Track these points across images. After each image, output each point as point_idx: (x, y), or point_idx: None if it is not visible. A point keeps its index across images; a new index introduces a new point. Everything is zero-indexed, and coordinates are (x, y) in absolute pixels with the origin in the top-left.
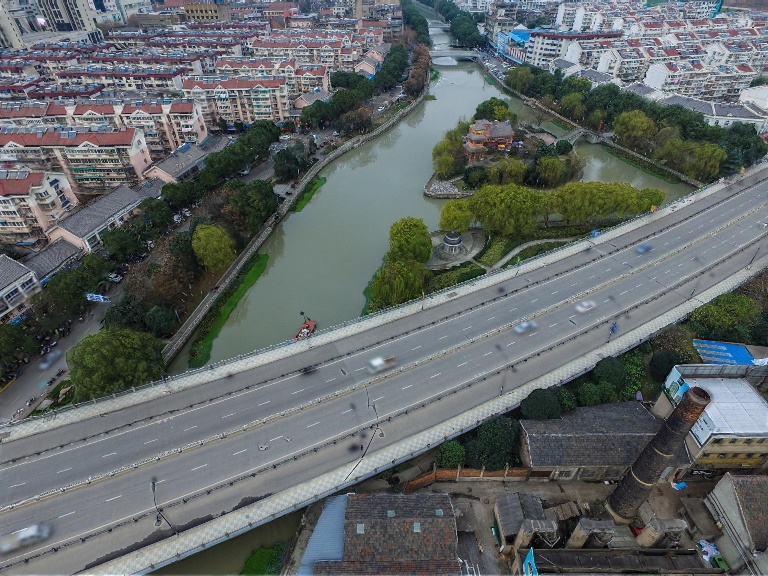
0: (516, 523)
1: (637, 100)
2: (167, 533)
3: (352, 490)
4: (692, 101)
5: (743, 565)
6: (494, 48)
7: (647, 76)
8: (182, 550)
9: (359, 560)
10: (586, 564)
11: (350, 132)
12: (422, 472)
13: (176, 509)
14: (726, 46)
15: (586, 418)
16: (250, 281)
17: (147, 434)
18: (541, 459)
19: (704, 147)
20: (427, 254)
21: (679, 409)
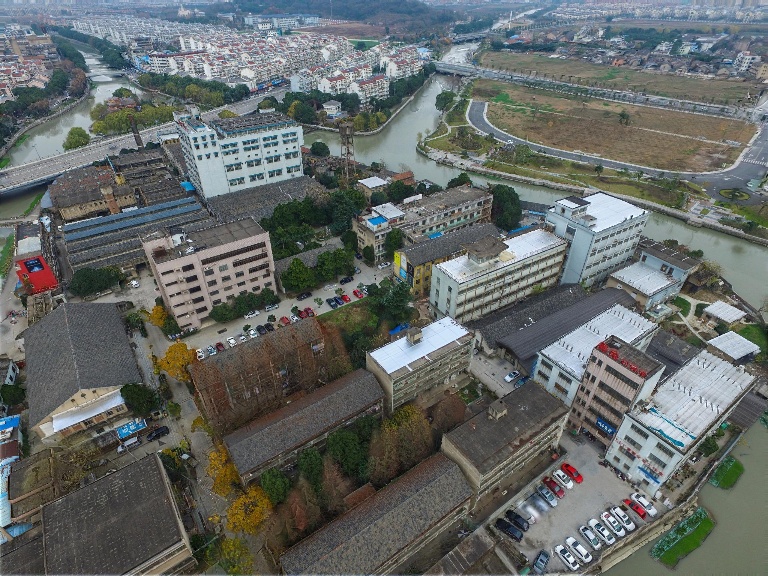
0: None
1: (199, 81)
2: None
3: None
4: (221, 78)
5: None
6: (135, 67)
7: (205, 70)
8: None
9: None
10: None
11: (37, 116)
12: None
13: (8, 184)
14: (248, 54)
15: None
16: (4, 164)
17: None
18: None
19: (215, 93)
20: (85, 136)
21: None
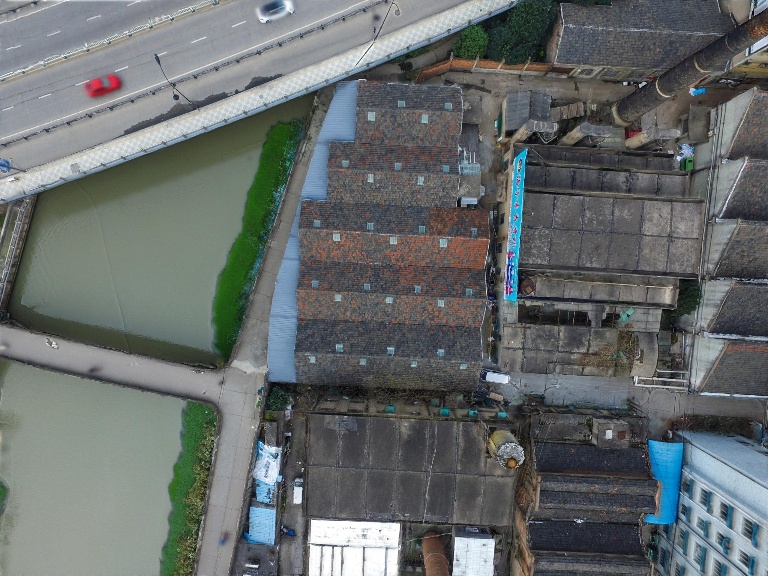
0: (520, 120)
1: None
2: (188, 107)
3: (363, 76)
4: None
5: (707, 168)
6: None
7: None
8: (207, 124)
9: (369, 143)
10: (570, 159)
11: None
12: (437, 60)
13: (189, 84)
14: None
15: (640, 6)
16: None
17: None
18: (568, 55)
19: None
20: None
21: (754, 22)
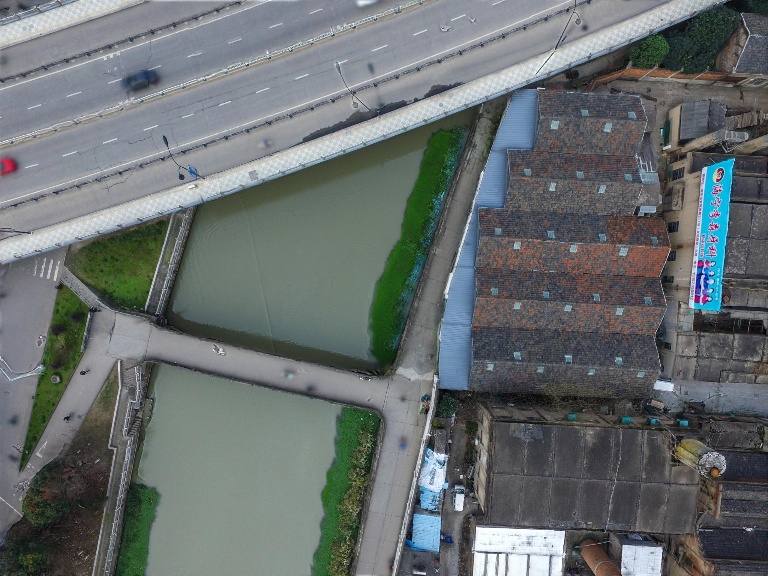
0: (697, 129)
1: None
2: (367, 115)
3: (542, 85)
4: None
5: None
6: None
7: None
8: (386, 132)
9: (548, 151)
10: (748, 168)
11: None
12: (612, 69)
13: (369, 92)
14: None
15: None
16: None
17: (308, 1)
18: (749, 65)
19: None
20: None
21: None
